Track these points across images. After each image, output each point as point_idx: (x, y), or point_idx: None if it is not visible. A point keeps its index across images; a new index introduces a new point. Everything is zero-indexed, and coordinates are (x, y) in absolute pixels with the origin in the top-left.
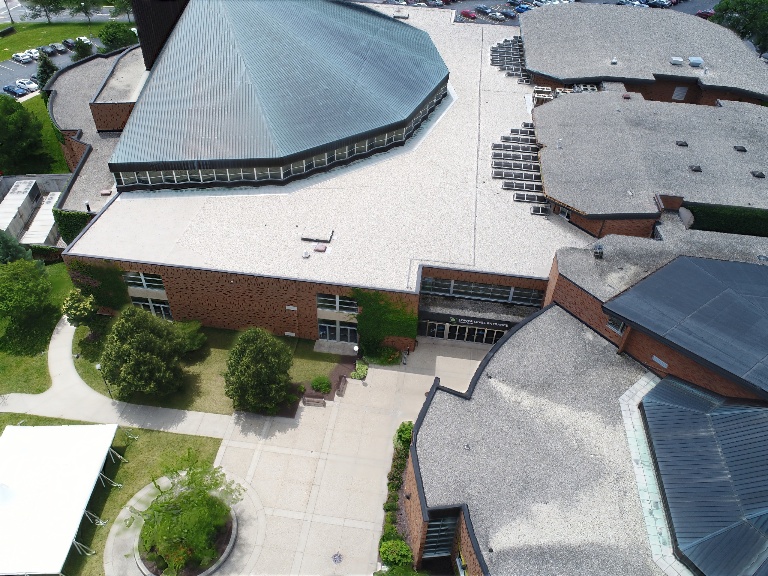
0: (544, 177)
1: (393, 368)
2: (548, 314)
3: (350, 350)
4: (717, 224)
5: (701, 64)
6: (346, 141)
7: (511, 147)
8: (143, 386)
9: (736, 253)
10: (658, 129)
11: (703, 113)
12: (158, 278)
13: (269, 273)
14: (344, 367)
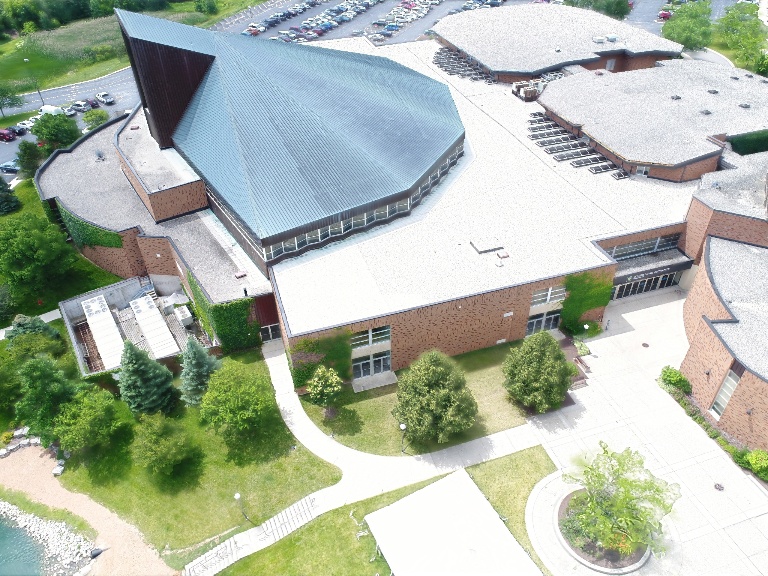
0: (611, 148)
1: (602, 336)
2: (714, 245)
3: (557, 336)
4: (747, 148)
5: None
6: (439, 161)
7: (545, 134)
8: (464, 424)
9: None
10: (648, 91)
11: (660, 73)
12: (385, 329)
13: (489, 288)
14: (567, 350)
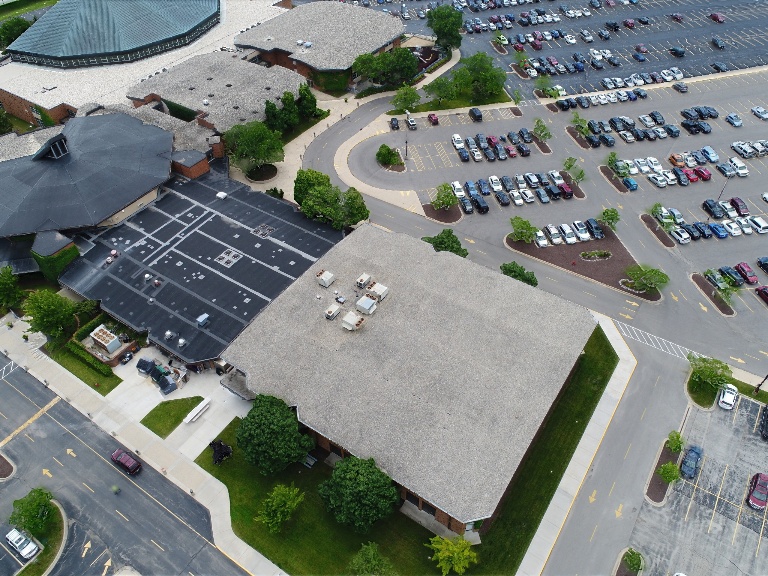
0: None
1: None
2: None
3: None
4: None
5: (313, 47)
6: (93, 55)
7: None
8: None
9: (151, 118)
10: None
11: (252, 69)
12: None
13: None
14: None
